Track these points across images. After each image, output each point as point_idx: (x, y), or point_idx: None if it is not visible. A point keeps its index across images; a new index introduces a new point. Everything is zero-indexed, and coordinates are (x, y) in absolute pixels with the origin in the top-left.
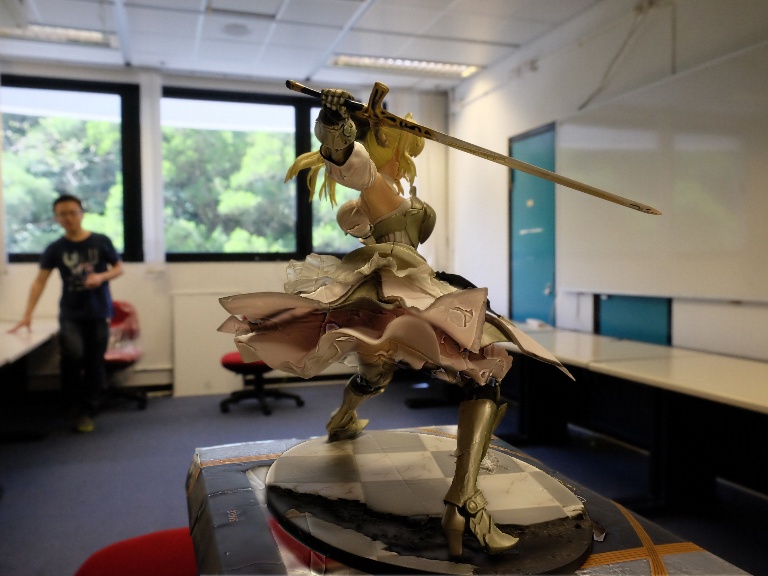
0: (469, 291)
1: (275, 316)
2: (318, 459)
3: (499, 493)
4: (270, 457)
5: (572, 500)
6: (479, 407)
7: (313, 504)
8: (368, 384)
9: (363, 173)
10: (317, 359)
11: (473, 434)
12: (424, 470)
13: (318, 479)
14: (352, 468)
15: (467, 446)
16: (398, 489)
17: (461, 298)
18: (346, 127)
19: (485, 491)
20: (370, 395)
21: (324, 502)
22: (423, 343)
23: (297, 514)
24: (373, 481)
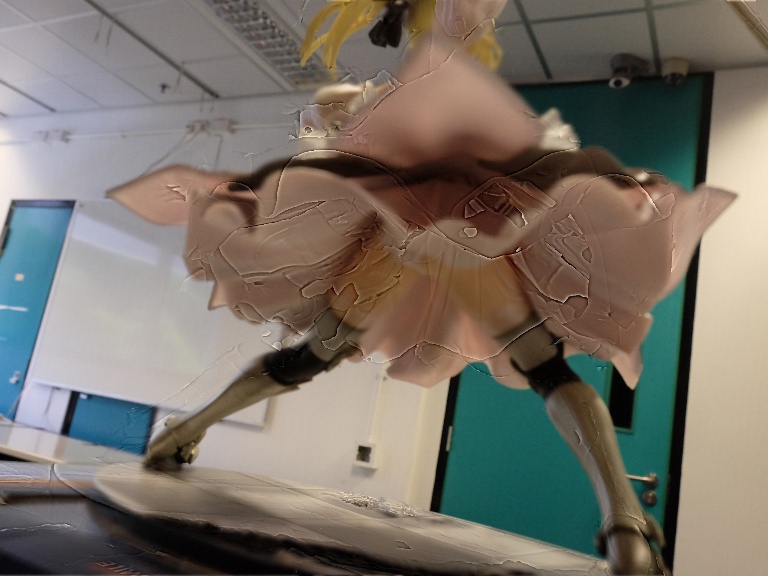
0: (721, 195)
1: (466, 124)
2: (143, 482)
3: (473, 537)
4: (6, 478)
5: (558, 544)
6: (576, 387)
7: (271, 547)
8: (302, 350)
9: None
10: None
11: (593, 421)
12: (328, 508)
13: (206, 510)
14: (221, 499)
15: (591, 438)
16: (351, 529)
17: (710, 201)
18: None
19: (452, 535)
20: (267, 375)
21: (284, 544)
22: (648, 253)
23: (309, 557)
24: (294, 517)
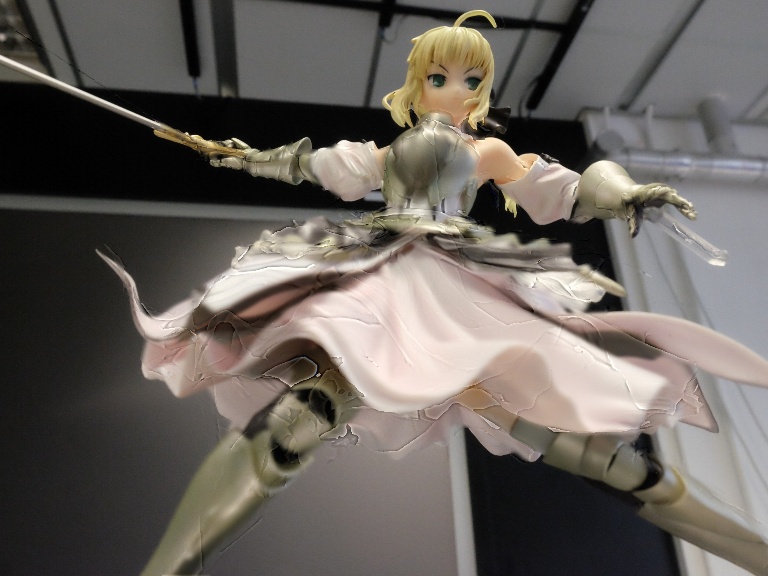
0: None
1: (270, 392)
2: None
3: None
4: None
5: None
6: None
7: None
8: (578, 473)
9: (324, 171)
10: (223, 426)
11: None
12: None
13: None
14: None
15: None
16: None
17: None
18: (250, 157)
19: None
20: None
21: None
22: None
23: None
24: None
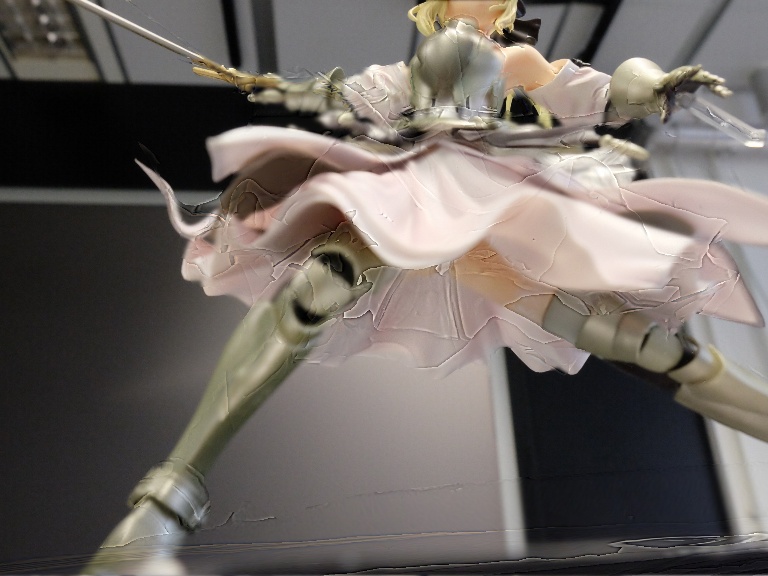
0: None
1: None
2: None
3: None
4: None
5: None
6: None
7: None
8: (611, 358)
9: None
10: None
11: None
12: None
13: None
14: None
15: None
16: None
17: None
18: None
19: None
20: (696, 385)
21: None
22: None
23: None
24: None
